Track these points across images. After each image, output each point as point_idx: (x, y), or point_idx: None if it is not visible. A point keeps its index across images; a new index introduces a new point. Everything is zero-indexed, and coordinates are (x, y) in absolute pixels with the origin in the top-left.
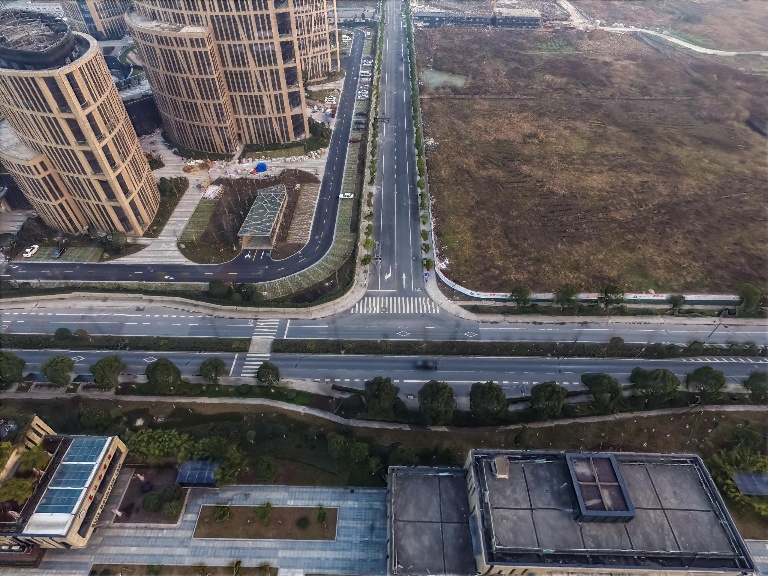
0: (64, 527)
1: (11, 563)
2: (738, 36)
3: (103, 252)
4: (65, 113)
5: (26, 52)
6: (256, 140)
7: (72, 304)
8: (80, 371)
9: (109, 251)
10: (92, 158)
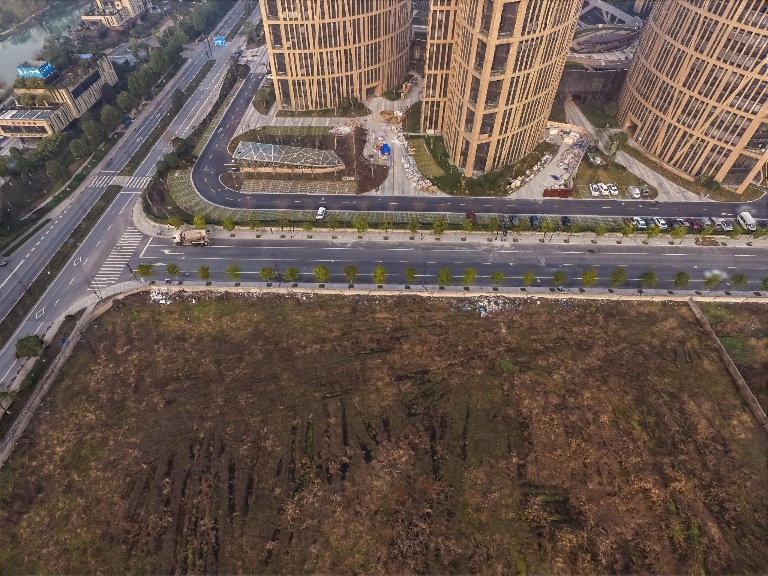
0: None
1: None
2: None
3: None
4: None
5: None
6: None
7: None
8: (146, 118)
9: None
10: (274, 31)
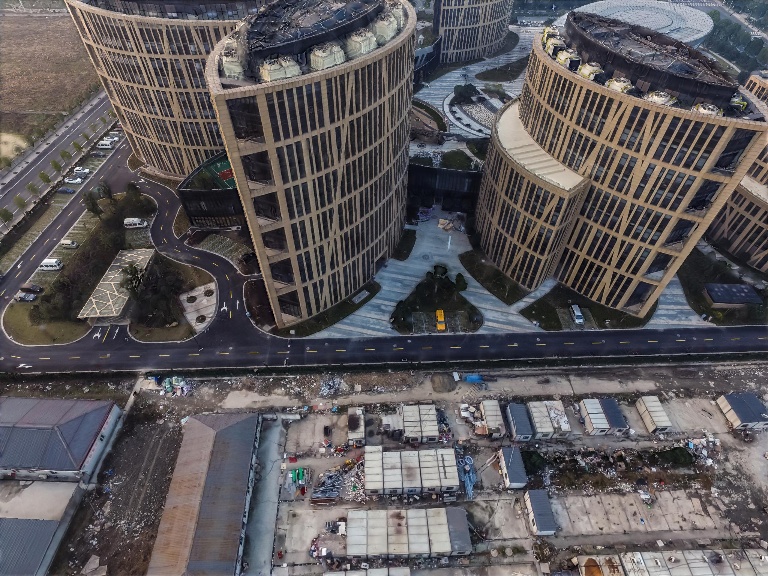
0: None
1: None
2: None
3: None
4: None
5: None
6: None
7: None
8: None
9: None
10: None
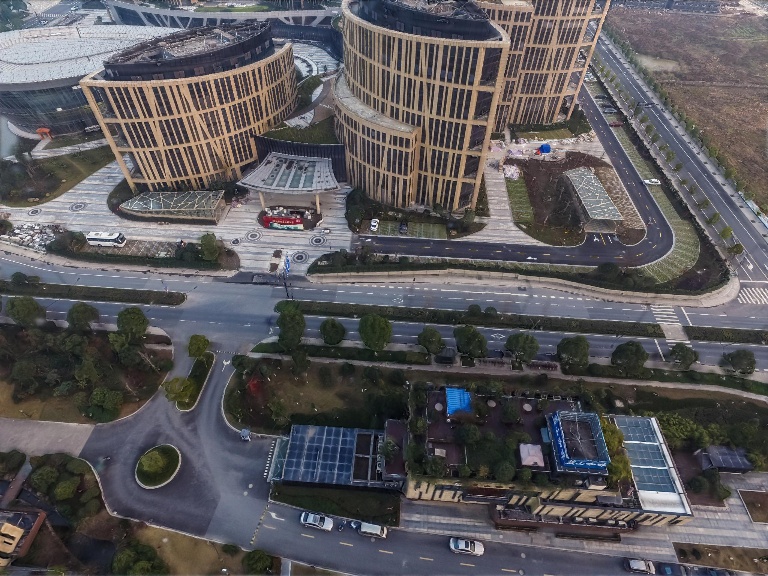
0: (681, 506)
1: (596, 537)
2: None
3: (448, 229)
4: (485, 86)
5: (466, 21)
6: (520, 120)
7: (450, 280)
8: None
9: (458, 228)
10: (474, 133)
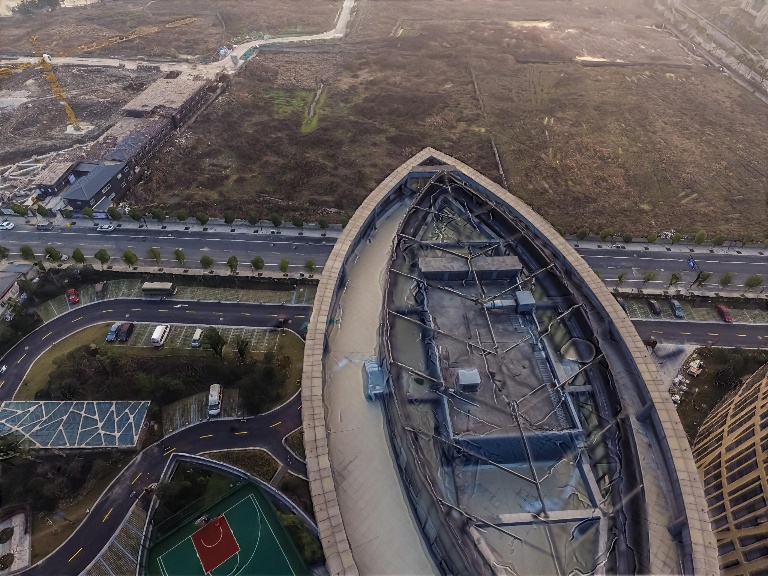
0: None
1: None
2: (299, 14)
3: None
4: None
5: None
6: None
7: None
8: None
9: None
10: None
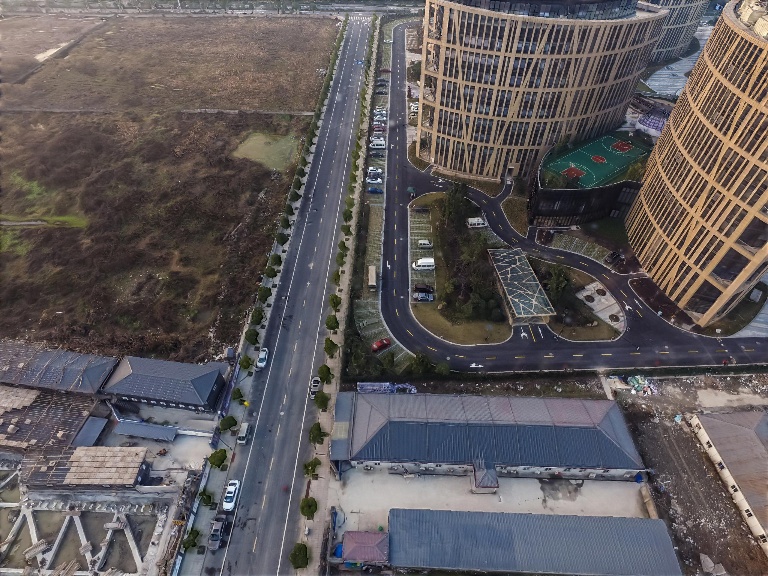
0: None
1: None
2: None
3: None
4: None
5: None
6: None
7: None
8: None
9: None
10: None
